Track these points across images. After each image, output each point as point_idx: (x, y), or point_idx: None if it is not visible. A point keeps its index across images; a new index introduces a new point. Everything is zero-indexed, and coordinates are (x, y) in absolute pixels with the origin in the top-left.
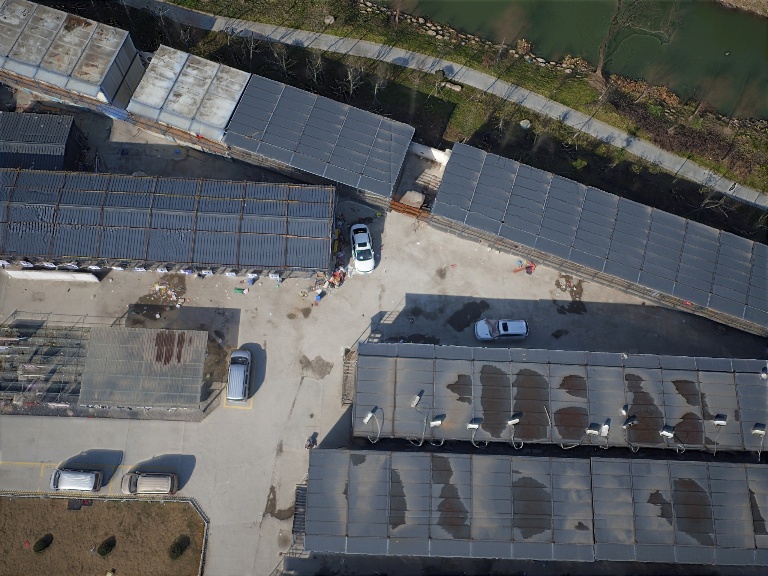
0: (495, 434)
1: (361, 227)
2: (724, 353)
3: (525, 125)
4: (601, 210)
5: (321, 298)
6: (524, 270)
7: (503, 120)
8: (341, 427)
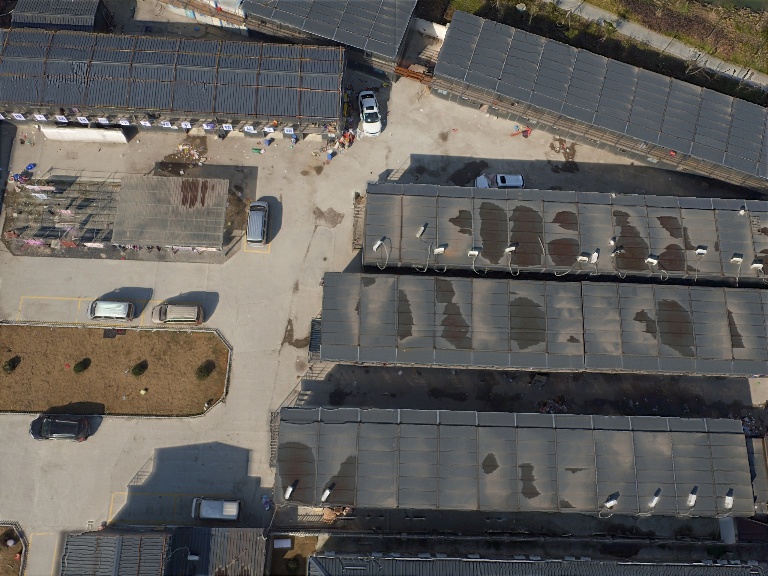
0: (493, 261)
1: (368, 93)
2: None
3: (521, 8)
4: (591, 70)
5: (332, 157)
6: (520, 134)
7: (500, 3)
8: (352, 269)
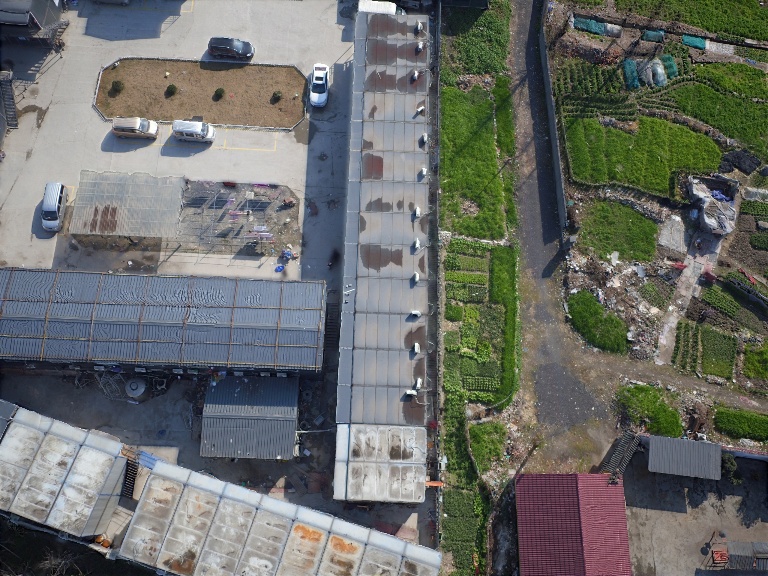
0: None
1: None
2: None
3: None
4: None
5: None
6: None
7: None
8: None
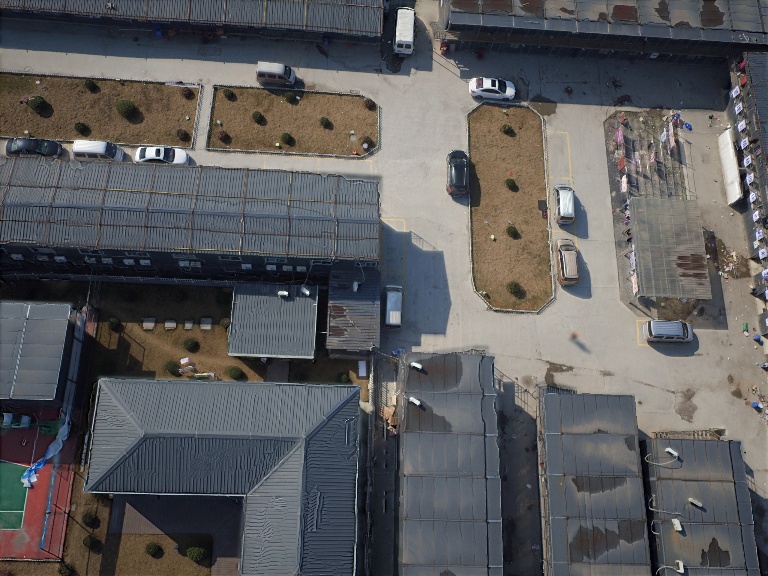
0: None
1: None
2: None
3: None
4: None
5: (754, 408)
6: None
7: None
8: None
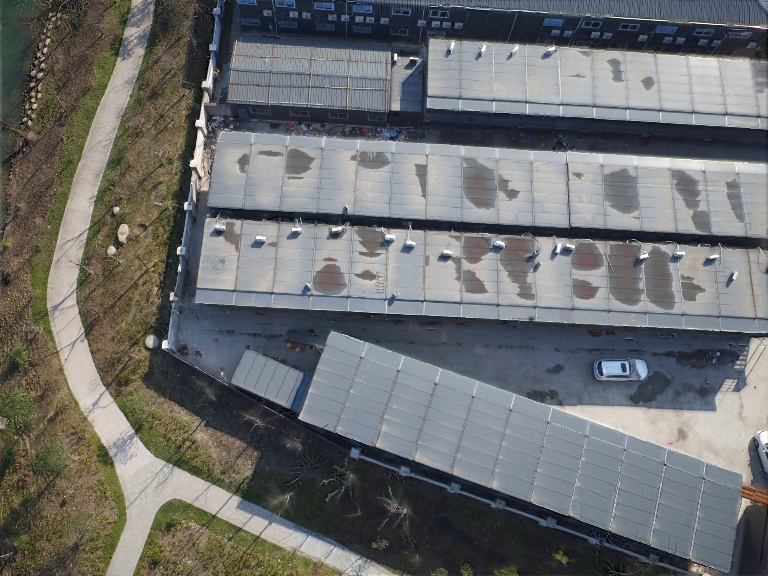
0: (657, 249)
1: None
2: (385, 348)
3: None
4: (553, 483)
5: None
6: None
7: None
8: None
